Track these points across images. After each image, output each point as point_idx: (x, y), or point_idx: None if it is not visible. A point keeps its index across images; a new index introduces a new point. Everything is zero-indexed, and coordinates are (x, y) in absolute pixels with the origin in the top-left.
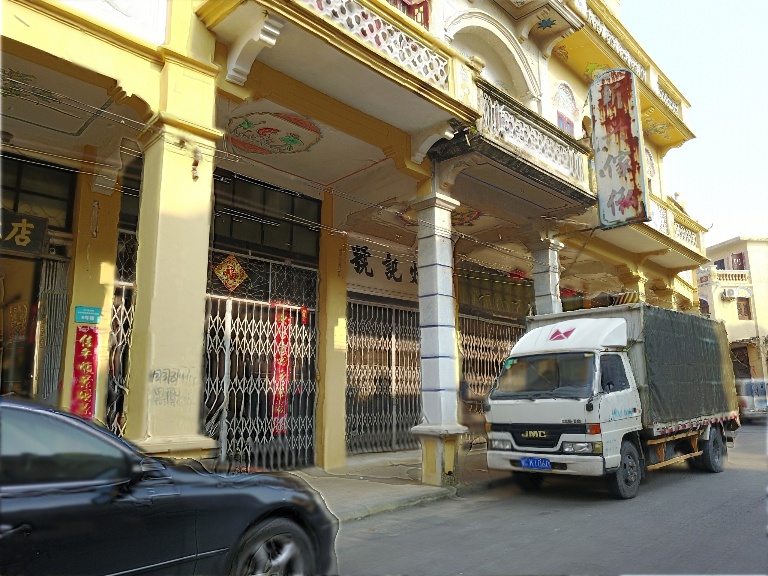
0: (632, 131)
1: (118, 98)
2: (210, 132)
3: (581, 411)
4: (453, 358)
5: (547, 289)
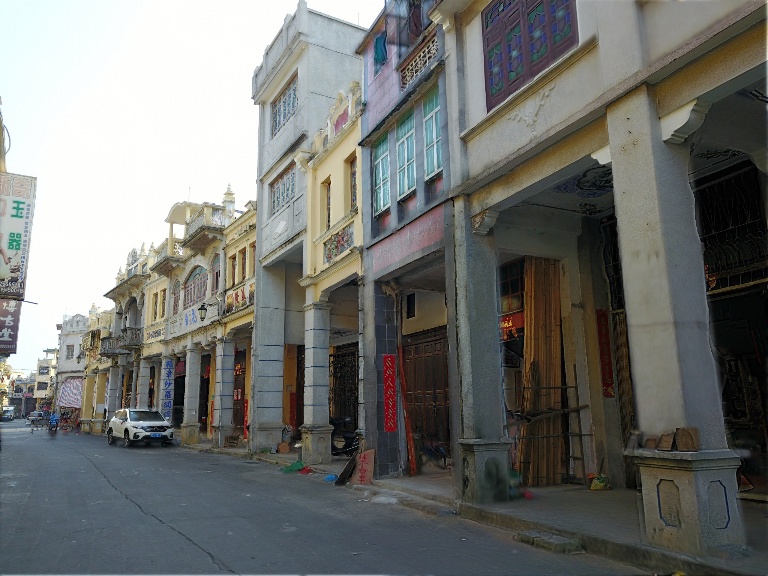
0: None
1: None
2: None
3: (11, 414)
4: None
5: (0, 402)
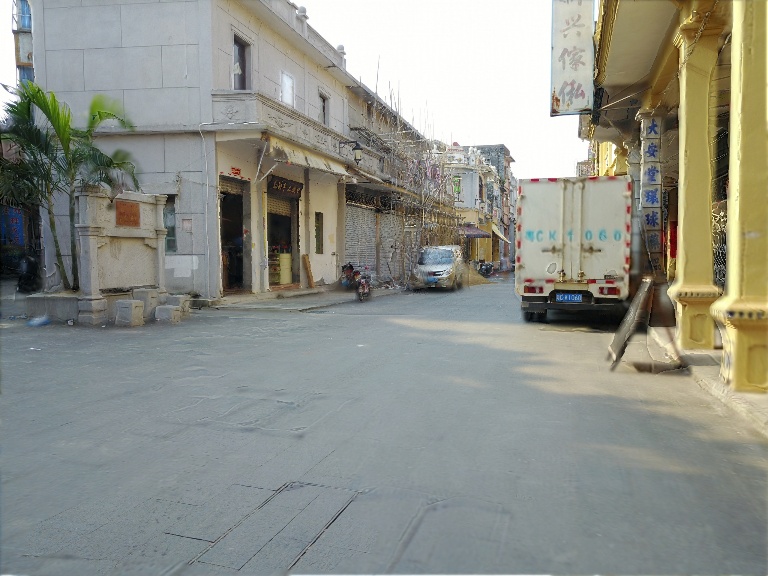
0: None
1: None
2: None
3: None
4: None
5: None
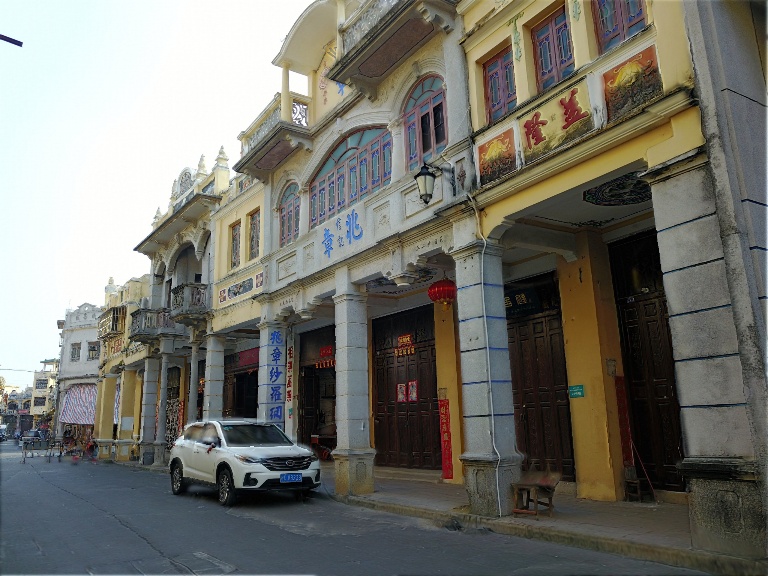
0: None
1: None
2: None
3: None
4: None
5: None
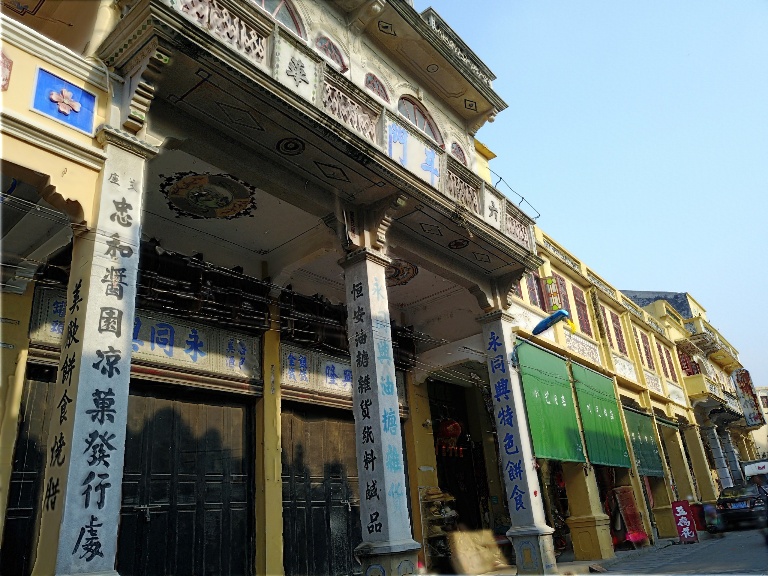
0: (753, 392)
1: (684, 421)
2: (698, 425)
3: None
4: (730, 478)
5: (731, 449)
